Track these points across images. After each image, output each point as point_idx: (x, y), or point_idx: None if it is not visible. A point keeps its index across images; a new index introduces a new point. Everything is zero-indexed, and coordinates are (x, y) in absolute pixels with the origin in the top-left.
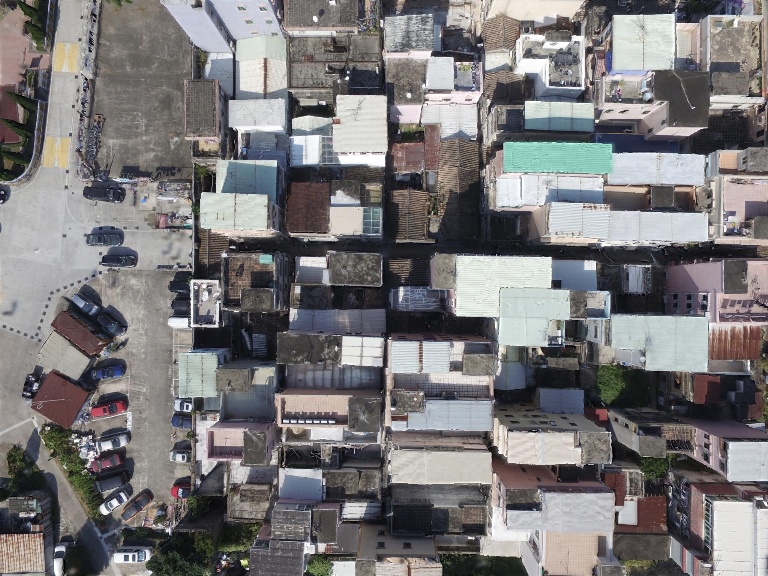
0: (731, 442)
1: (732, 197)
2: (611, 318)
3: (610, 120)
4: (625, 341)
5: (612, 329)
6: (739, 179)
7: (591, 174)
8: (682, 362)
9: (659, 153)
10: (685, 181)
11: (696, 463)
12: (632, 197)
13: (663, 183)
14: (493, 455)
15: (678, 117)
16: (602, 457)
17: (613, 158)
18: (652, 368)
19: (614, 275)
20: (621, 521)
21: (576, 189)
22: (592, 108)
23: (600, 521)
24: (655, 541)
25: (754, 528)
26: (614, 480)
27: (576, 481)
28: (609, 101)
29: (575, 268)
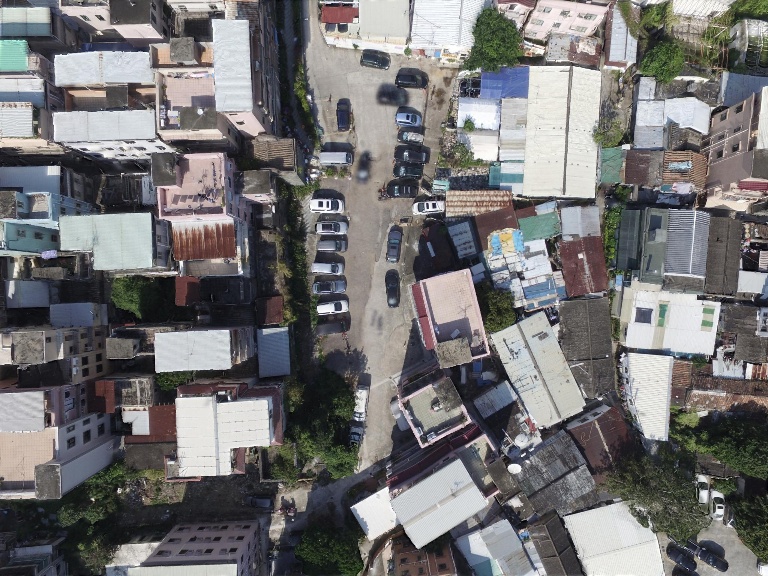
0: (156, 333)
1: (178, 92)
2: (59, 220)
3: (110, 31)
4: (72, 242)
5: (61, 231)
6: (181, 73)
7: (24, 75)
8: (129, 259)
9: (101, 52)
10: (132, 79)
11: (215, 370)
12: (105, 102)
13: (108, 82)
14: (5, 373)
15: (119, 15)
16: (36, 357)
17: (59, 59)
18: (100, 267)
19: (119, 186)
20: (135, 432)
21: (14, 91)
22: (48, 12)
23: (27, 420)
24: (167, 449)
25: (214, 422)
26: (103, 387)
27: (36, 386)
28: (65, 5)
29: (38, 174)
